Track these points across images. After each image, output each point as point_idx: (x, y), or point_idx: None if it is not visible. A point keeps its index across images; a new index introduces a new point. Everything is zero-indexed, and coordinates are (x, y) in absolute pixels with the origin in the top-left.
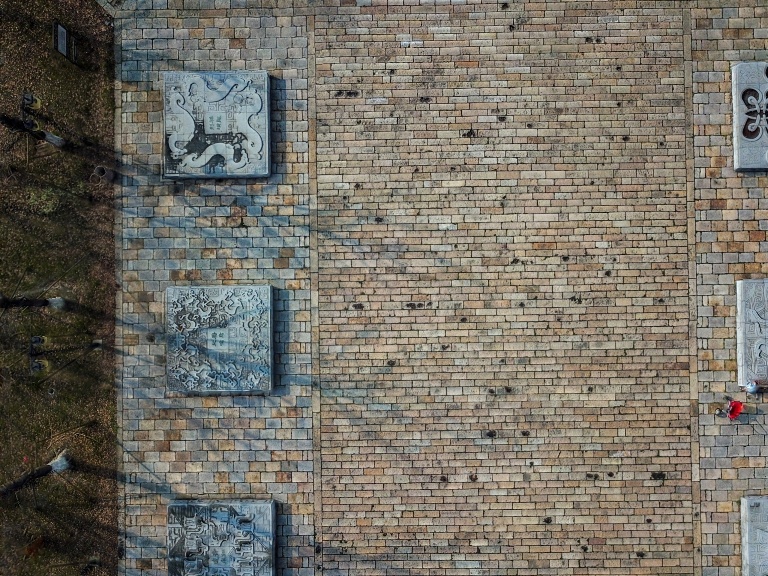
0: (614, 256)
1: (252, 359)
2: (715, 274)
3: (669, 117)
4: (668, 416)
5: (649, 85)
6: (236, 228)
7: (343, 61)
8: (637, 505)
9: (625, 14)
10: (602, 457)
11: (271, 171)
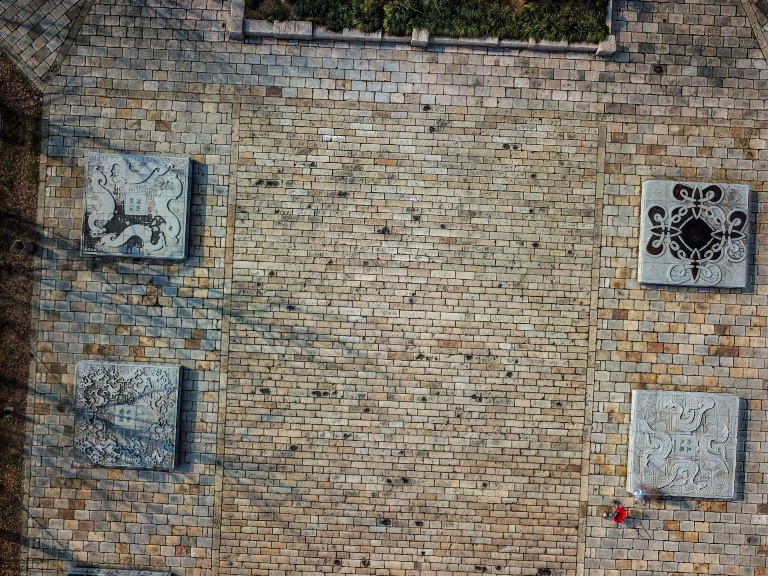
0: (516, 358)
1: (157, 437)
2: (612, 382)
3: (578, 226)
4: (557, 516)
5: (561, 194)
6: (151, 307)
7: (265, 150)
8: None
9: (543, 123)
10: (491, 551)
11: (188, 254)
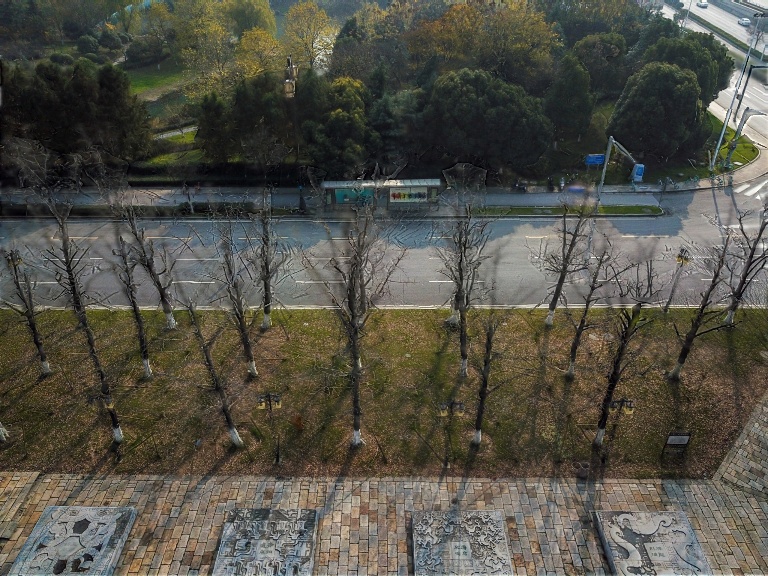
0: None
1: None
2: None
3: None
4: None
5: None
6: (564, 571)
7: None
8: None
9: None
10: None
11: None
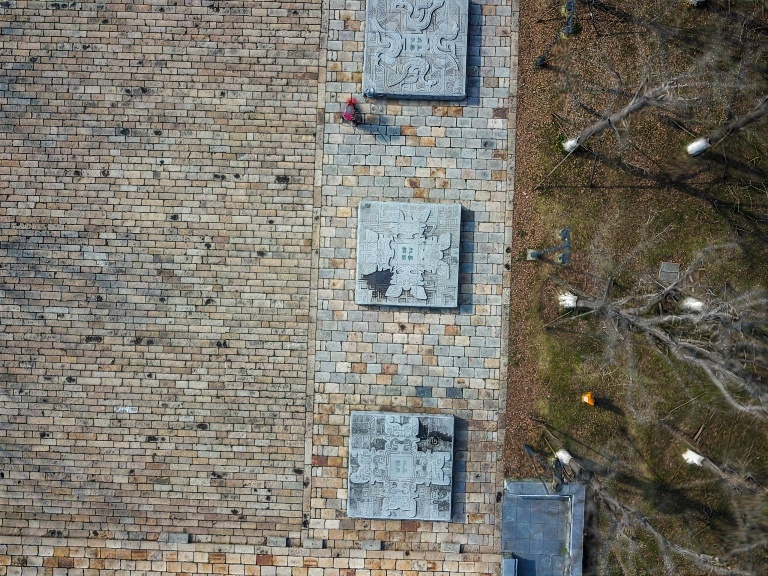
0: None
1: None
2: None
3: None
4: (295, 123)
5: None
6: None
7: None
8: (260, 206)
9: None
10: (230, 159)
11: None
